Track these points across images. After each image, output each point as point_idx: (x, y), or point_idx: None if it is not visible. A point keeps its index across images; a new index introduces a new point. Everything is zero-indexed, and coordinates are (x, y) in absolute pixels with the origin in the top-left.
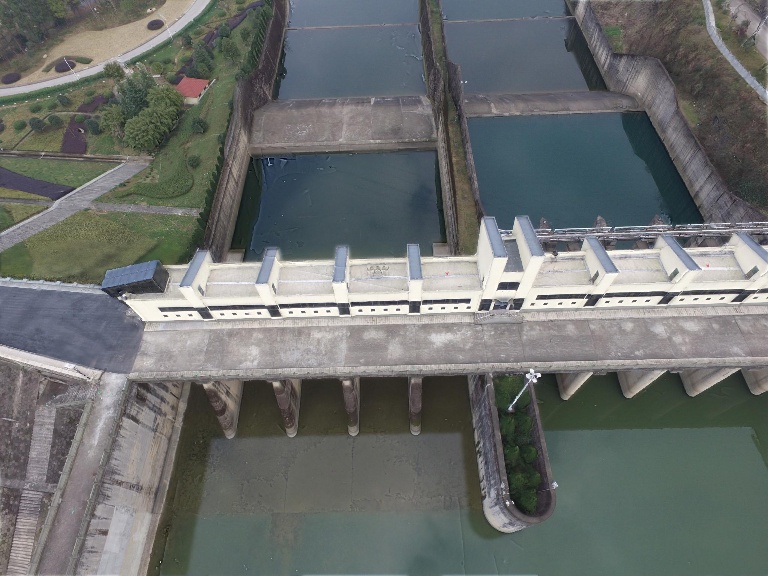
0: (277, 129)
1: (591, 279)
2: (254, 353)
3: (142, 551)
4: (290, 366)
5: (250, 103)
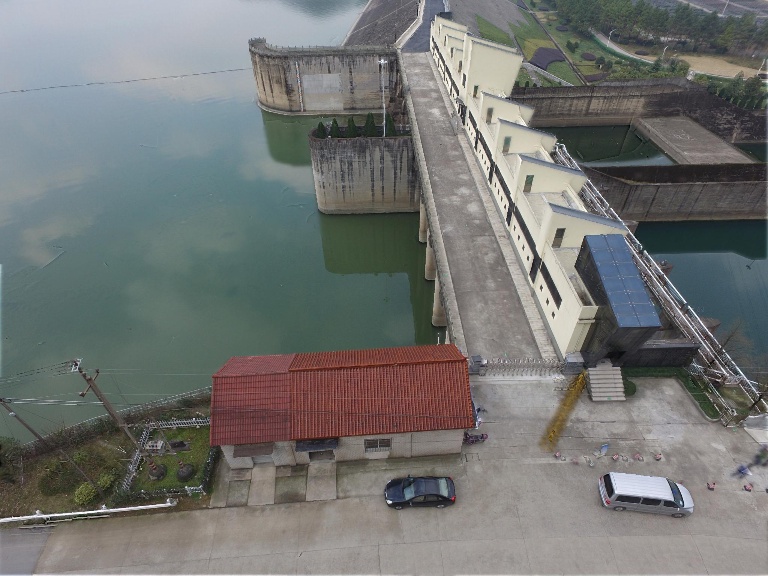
0: (672, 126)
1: None
2: (416, 71)
3: (327, 110)
4: (408, 78)
5: (690, 108)
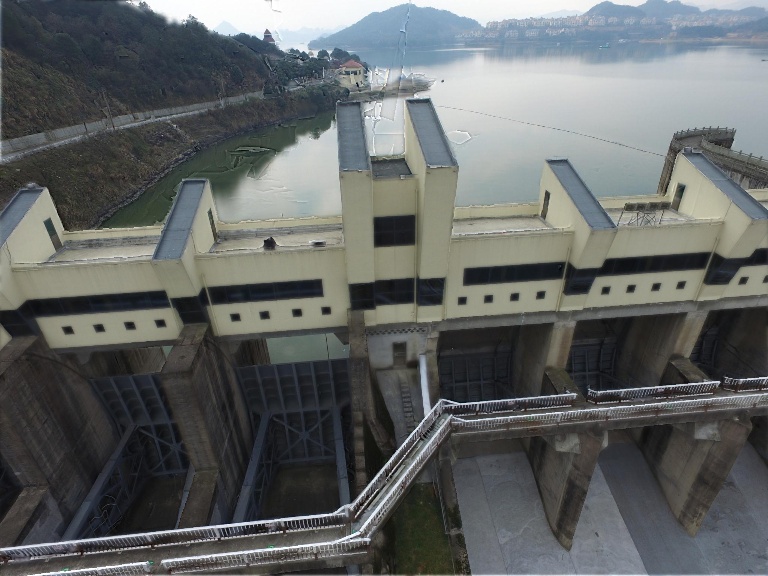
0: None
1: (216, 242)
2: None
3: None
4: None
5: None
